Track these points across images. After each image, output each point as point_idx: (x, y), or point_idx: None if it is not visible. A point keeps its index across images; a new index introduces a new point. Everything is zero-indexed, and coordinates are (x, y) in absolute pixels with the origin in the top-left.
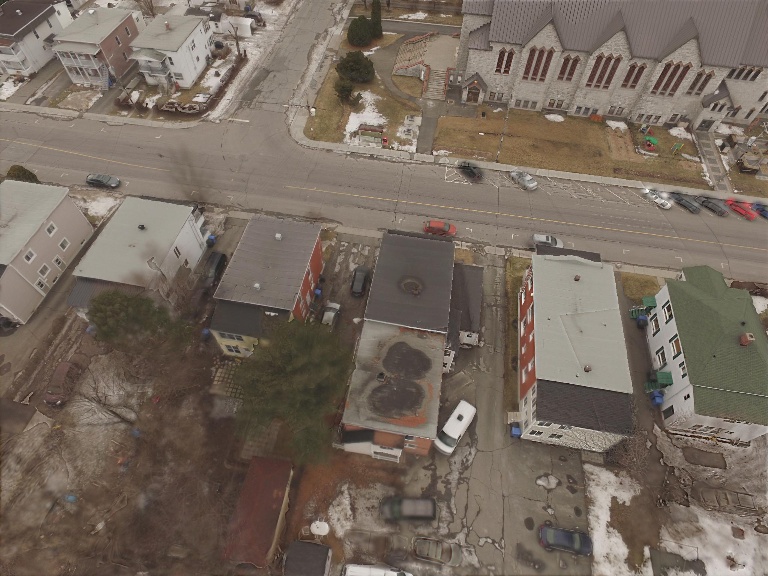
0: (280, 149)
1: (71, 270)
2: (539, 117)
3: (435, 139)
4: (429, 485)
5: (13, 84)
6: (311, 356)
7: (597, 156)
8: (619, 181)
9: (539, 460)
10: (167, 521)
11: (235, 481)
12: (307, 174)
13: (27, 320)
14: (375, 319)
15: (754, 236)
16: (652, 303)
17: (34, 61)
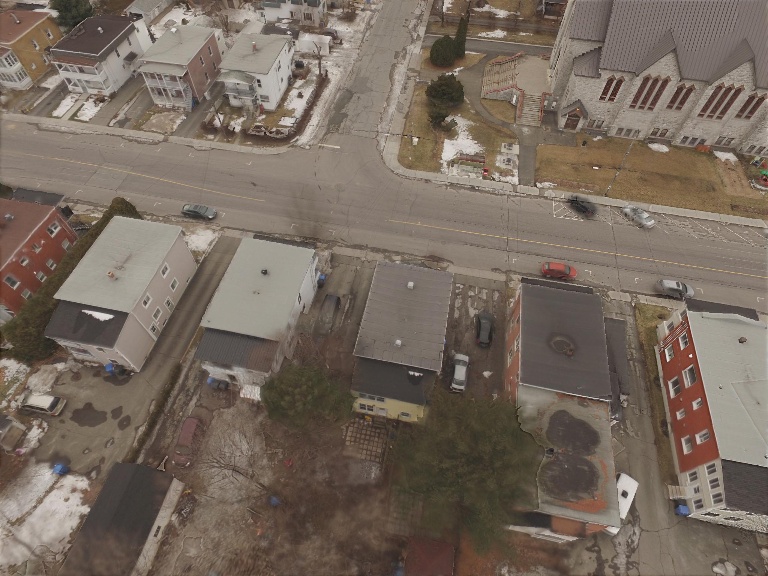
0: (376, 178)
1: (179, 311)
2: (642, 147)
3: (537, 170)
4: (596, 570)
5: (94, 104)
6: (524, 451)
7: (711, 191)
8: (739, 219)
9: (711, 543)
10: None
11: (385, 560)
12: (409, 207)
13: (141, 367)
14: (532, 384)
15: None
16: None
17: (114, 80)
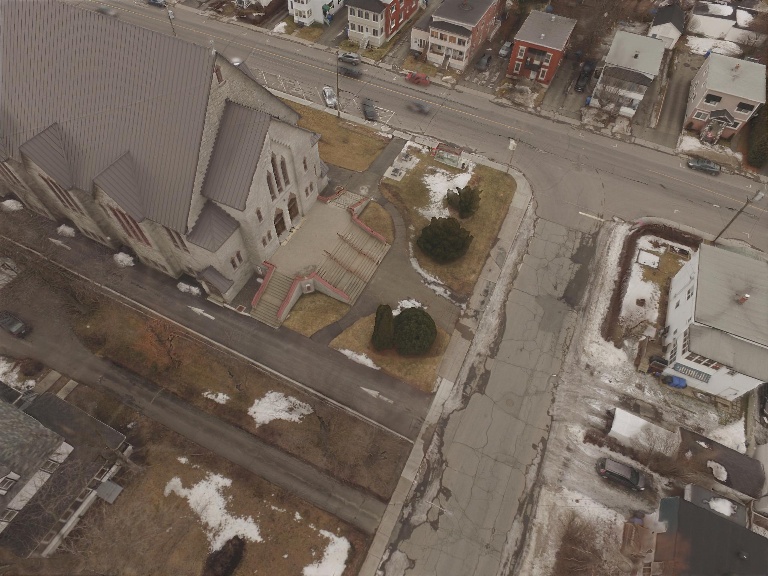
0: (541, 170)
1: (683, 103)
2: None
3: (383, 148)
4: None
5: None
6: None
7: None
8: None
9: None
10: (579, 13)
11: None
12: None
13: None
14: None
15: (202, 40)
16: (327, 5)
17: None
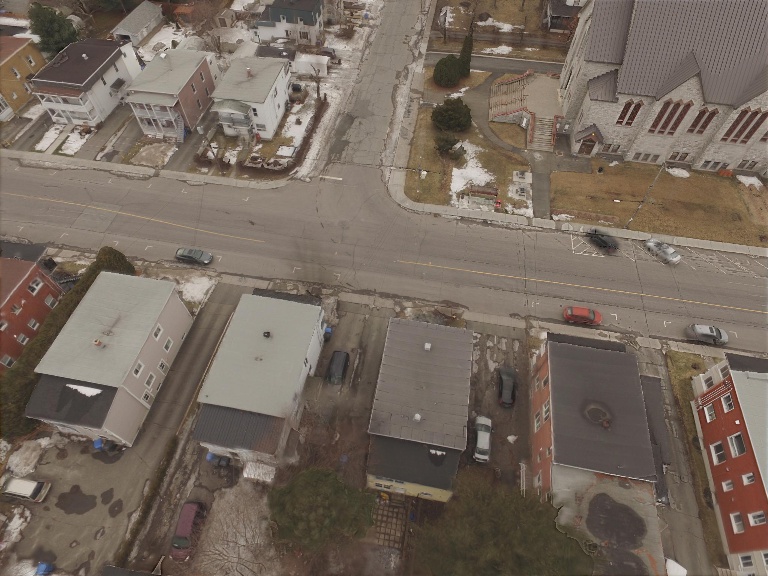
0: (382, 214)
1: (174, 373)
2: (661, 172)
3: (552, 200)
4: None
5: (79, 136)
6: None
7: (737, 220)
8: None
9: None
10: None
11: None
12: (418, 245)
13: (133, 441)
14: (567, 464)
15: None
16: None
17: (101, 110)
